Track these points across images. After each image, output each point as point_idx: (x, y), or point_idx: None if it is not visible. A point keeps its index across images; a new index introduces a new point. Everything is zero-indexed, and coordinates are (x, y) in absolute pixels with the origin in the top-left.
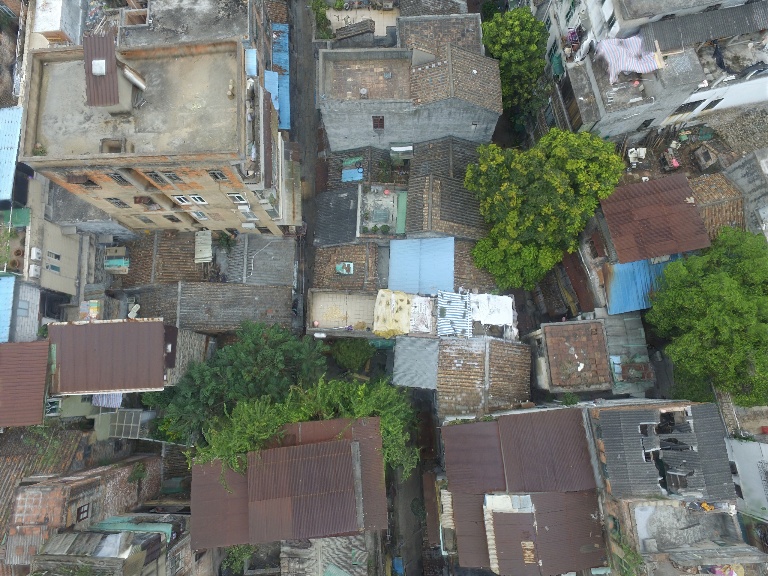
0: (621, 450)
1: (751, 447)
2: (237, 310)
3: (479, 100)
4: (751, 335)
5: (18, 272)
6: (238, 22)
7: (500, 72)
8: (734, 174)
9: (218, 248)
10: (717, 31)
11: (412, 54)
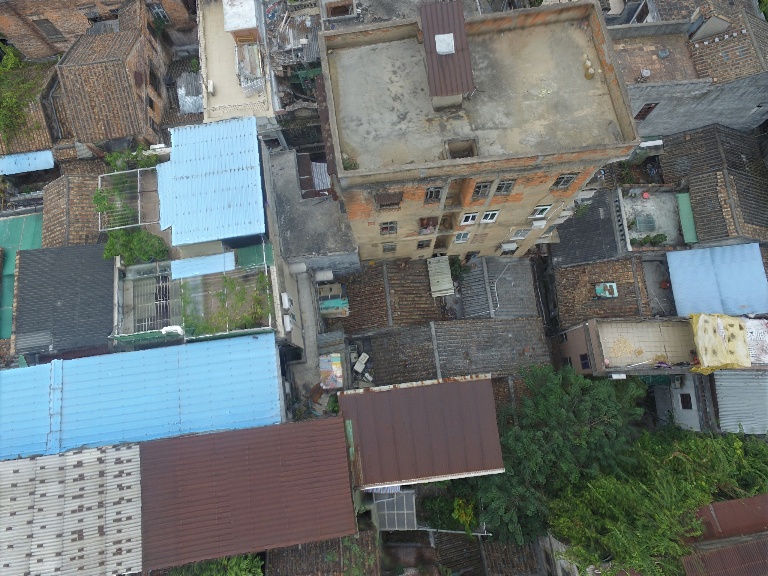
0: None
1: None
2: (495, 352)
3: None
4: None
5: None
6: (464, 5)
7: None
8: None
9: None
10: None
11: (702, 25)
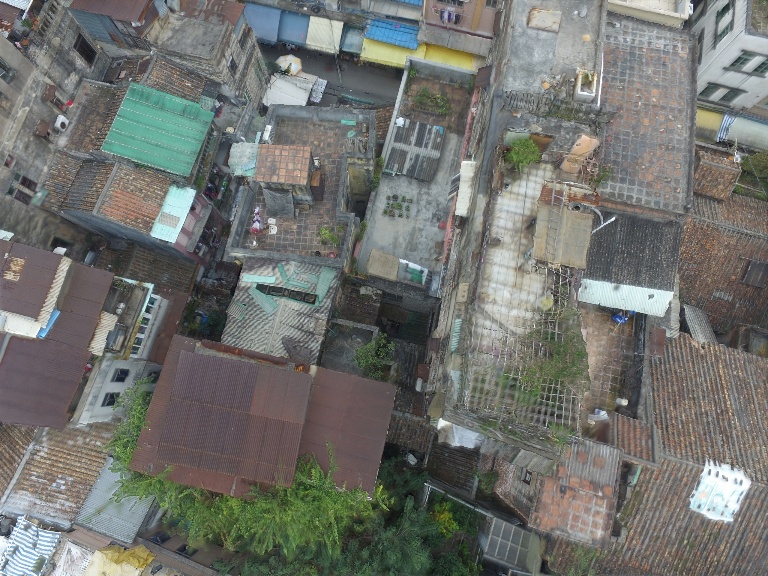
0: None
1: None
2: None
3: None
4: None
5: None
6: None
7: None
8: None
9: None
10: None
11: None
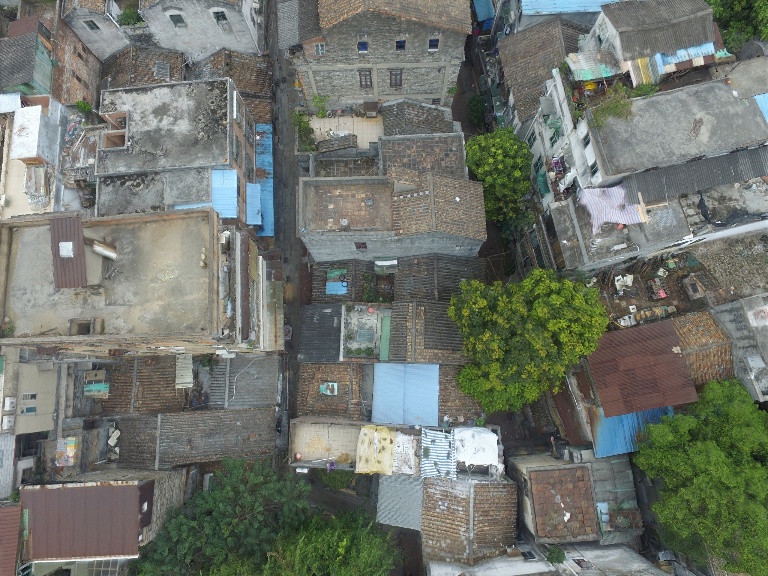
0: None
1: None
2: (218, 438)
3: (462, 230)
4: (739, 510)
5: None
6: (218, 144)
7: (485, 189)
8: (722, 316)
9: (201, 364)
10: (702, 181)
11: (393, 184)
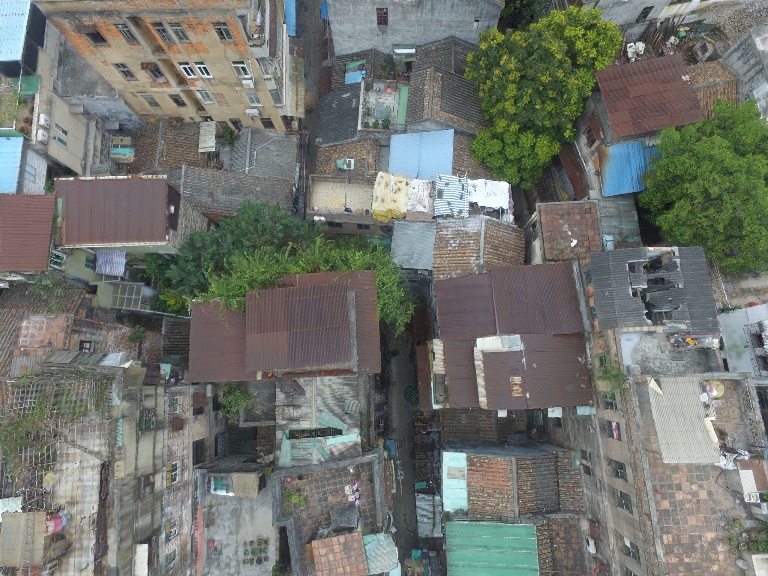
0: (609, 287)
1: (738, 315)
2: (239, 198)
3: None
4: (740, 194)
5: (26, 136)
6: None
7: None
8: (730, 59)
9: (222, 145)
10: None
11: None
